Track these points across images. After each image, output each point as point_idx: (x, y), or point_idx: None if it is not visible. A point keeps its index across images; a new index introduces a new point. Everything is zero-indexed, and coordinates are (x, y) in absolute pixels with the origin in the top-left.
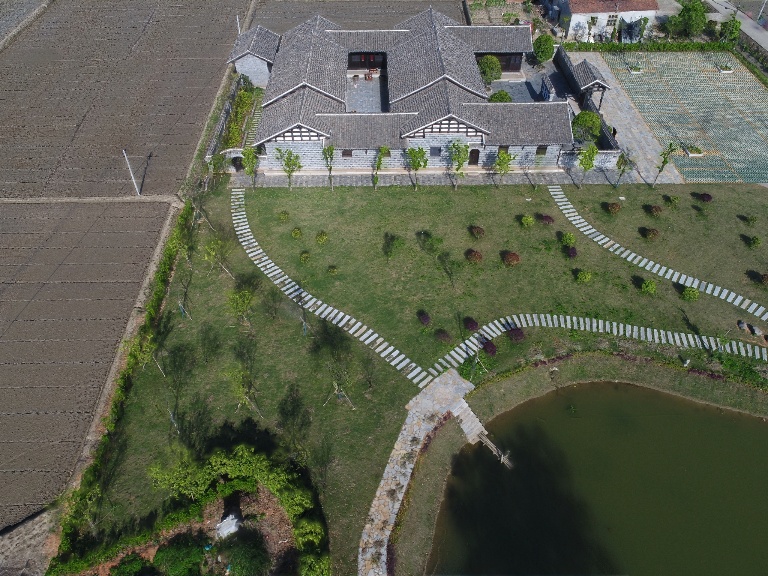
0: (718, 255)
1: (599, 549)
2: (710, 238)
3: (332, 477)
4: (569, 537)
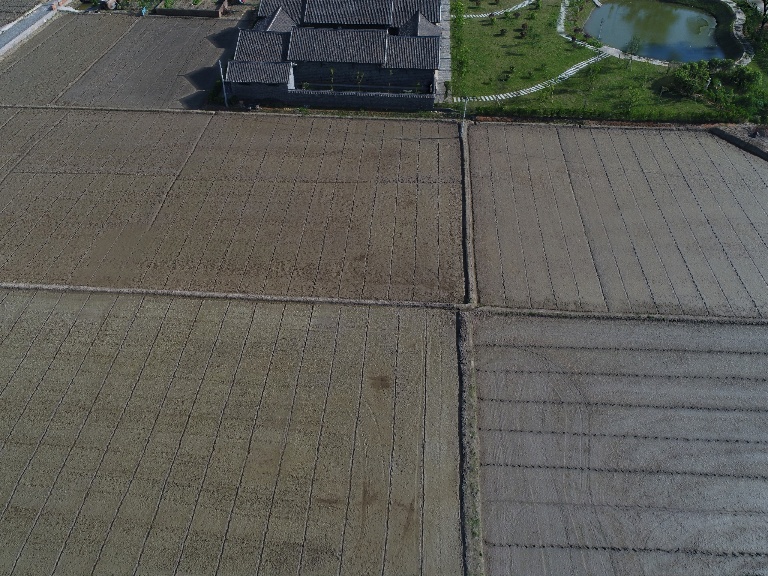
0: None
1: None
2: None
3: None
4: None
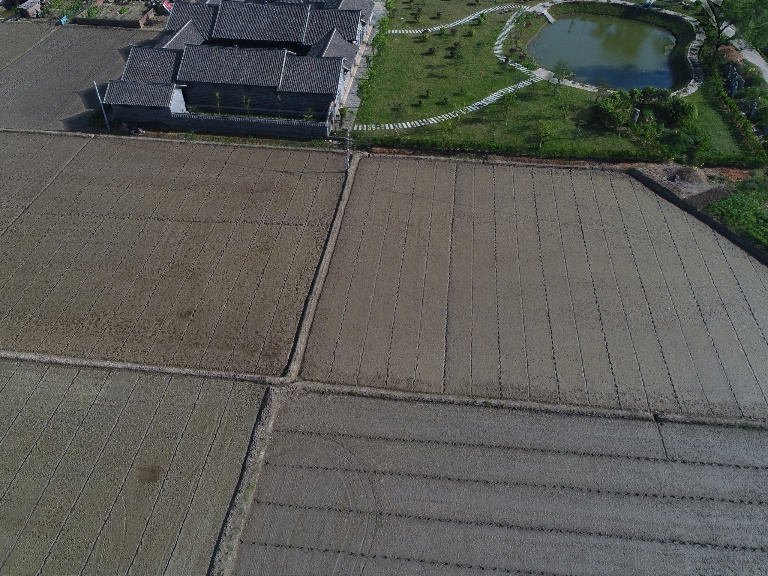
0: (455, 8)
1: (606, 65)
2: (442, 6)
3: (598, 100)
4: (602, 70)
